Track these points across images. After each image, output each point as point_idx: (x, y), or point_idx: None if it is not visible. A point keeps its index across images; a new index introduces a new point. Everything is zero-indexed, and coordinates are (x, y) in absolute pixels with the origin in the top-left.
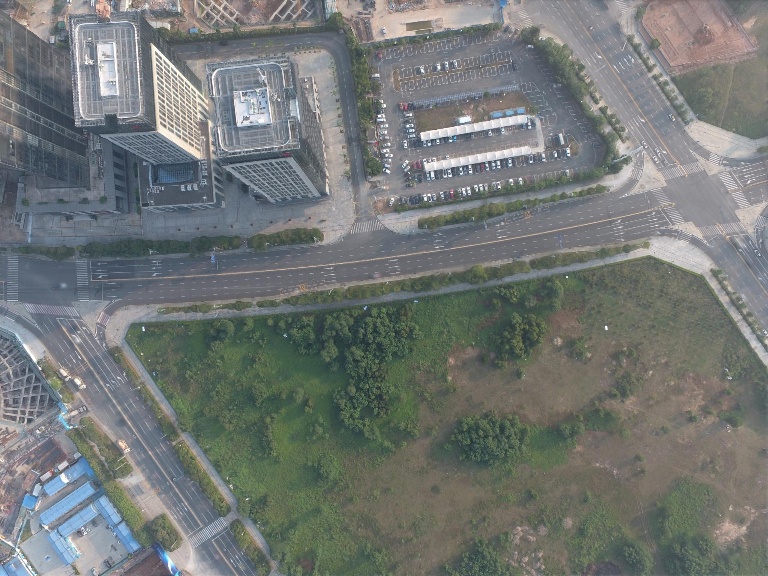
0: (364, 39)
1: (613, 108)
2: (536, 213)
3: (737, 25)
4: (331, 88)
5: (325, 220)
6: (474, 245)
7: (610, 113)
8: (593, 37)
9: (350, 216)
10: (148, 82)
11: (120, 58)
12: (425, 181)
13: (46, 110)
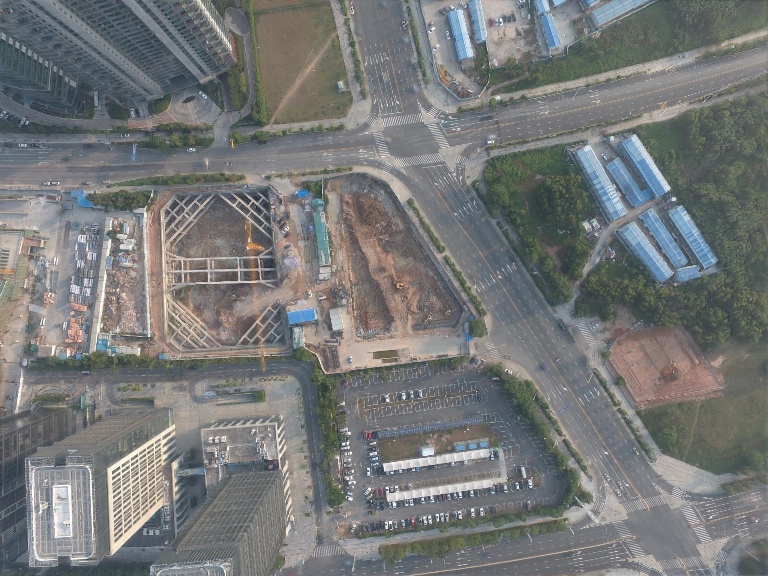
0: (331, 367)
1: (577, 440)
2: (496, 542)
3: (704, 363)
4: (297, 414)
5: (287, 544)
6: (434, 573)
7: (574, 445)
8: (559, 369)
9: (312, 540)
10: (102, 516)
11: (75, 499)
12: (387, 508)
13: (8, 496)
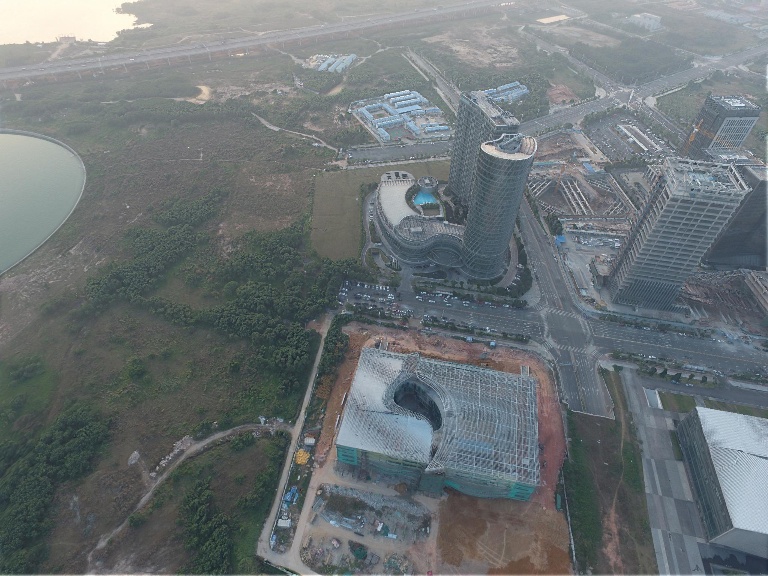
0: None
1: None
2: None
3: None
4: (638, 174)
5: None
6: None
7: None
8: None
9: None
10: None
11: None
12: None
13: None
